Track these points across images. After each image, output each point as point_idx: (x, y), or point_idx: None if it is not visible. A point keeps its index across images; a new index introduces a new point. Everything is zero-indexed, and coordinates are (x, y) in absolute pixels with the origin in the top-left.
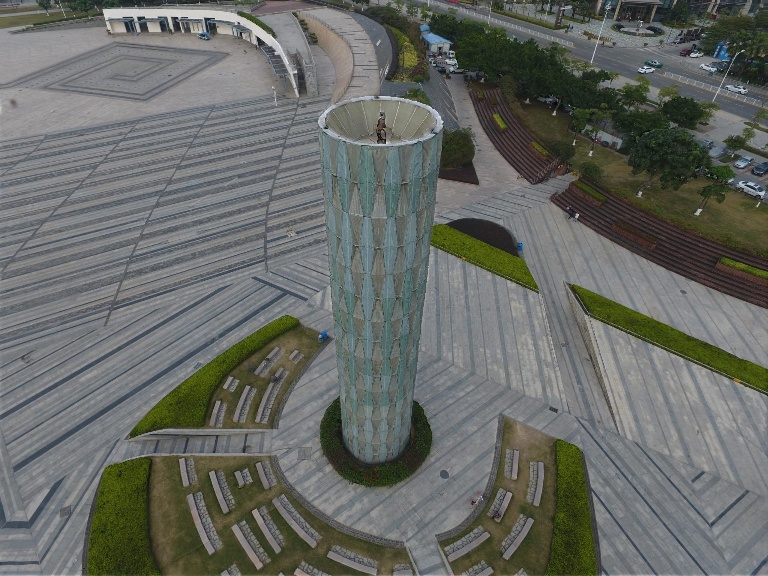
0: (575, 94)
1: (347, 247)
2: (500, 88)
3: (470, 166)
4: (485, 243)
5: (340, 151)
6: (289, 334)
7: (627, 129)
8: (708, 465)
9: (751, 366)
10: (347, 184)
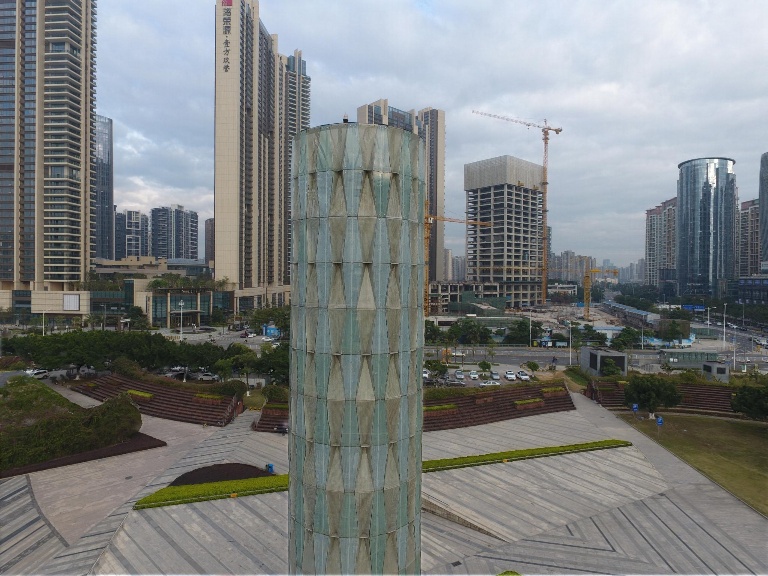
0: (205, 354)
1: (378, 275)
2: (117, 371)
3: (140, 434)
4: (234, 480)
5: (377, 138)
6: None
7: (266, 367)
8: (562, 519)
9: (496, 453)
10: (386, 178)
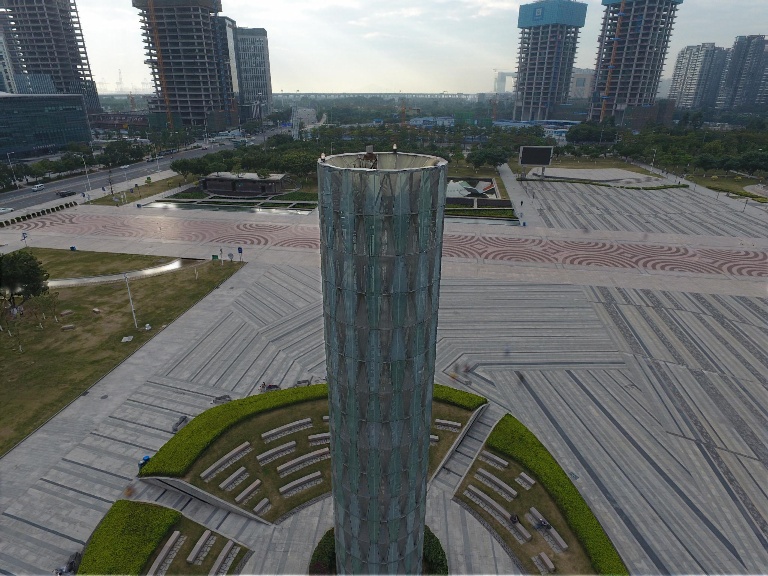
0: None
1: None
2: None
3: None
4: None
5: None
6: (591, 575)
7: None
8: None
9: None
10: None
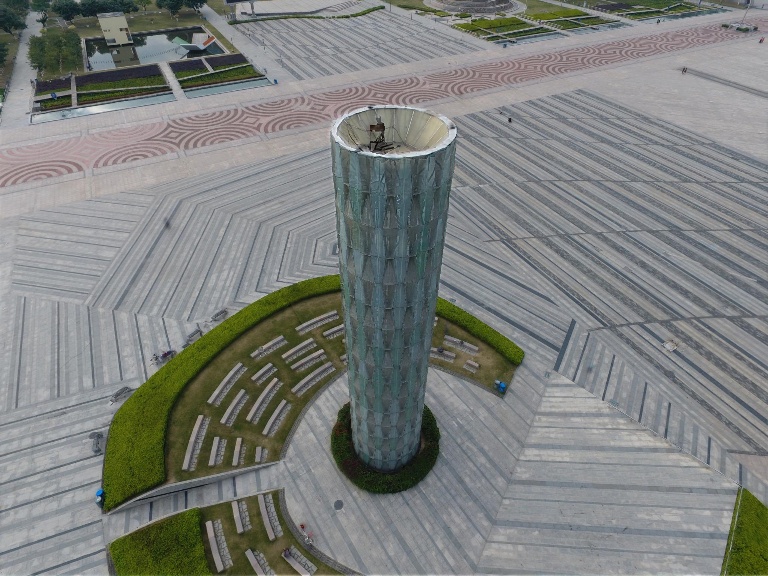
0: None
1: None
2: None
3: None
4: None
5: None
6: (499, 357)
7: None
8: None
9: None
10: None
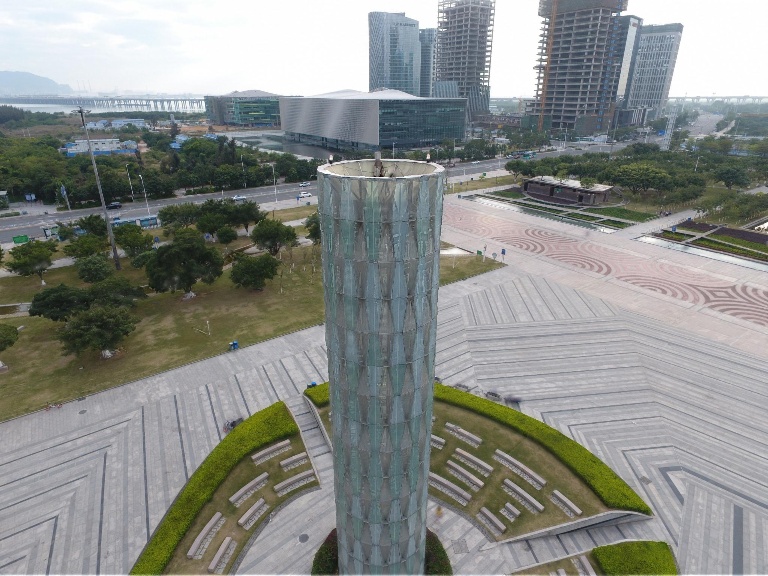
0: None
1: None
2: None
3: None
4: None
5: None
6: None
7: None
8: None
9: None
10: None
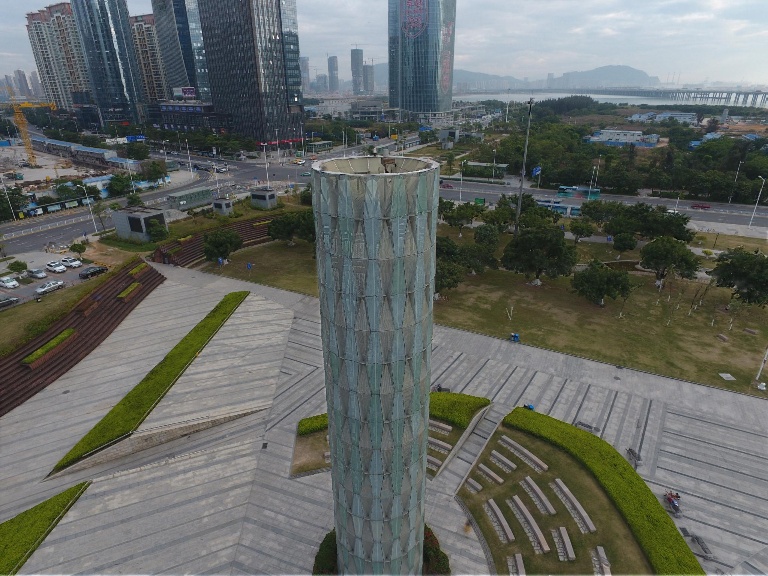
0: None
1: None
2: None
3: None
4: None
5: None
6: None
7: None
8: (275, 370)
9: (174, 353)
10: None
